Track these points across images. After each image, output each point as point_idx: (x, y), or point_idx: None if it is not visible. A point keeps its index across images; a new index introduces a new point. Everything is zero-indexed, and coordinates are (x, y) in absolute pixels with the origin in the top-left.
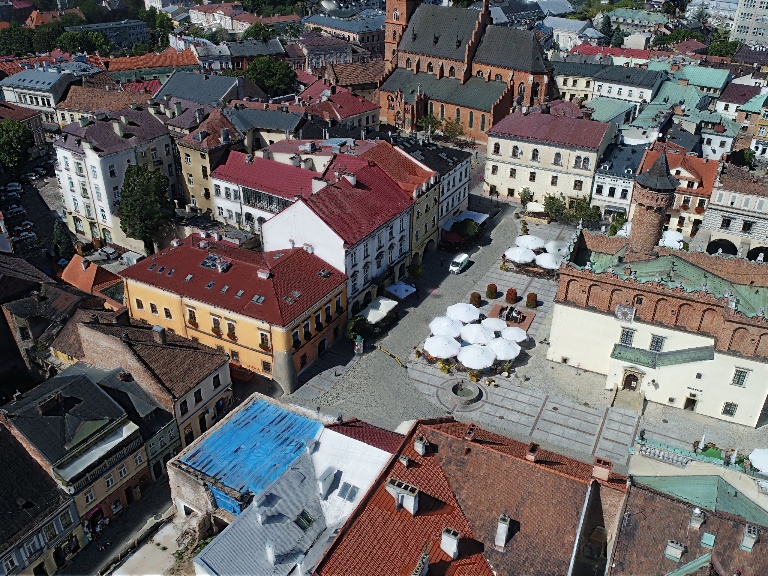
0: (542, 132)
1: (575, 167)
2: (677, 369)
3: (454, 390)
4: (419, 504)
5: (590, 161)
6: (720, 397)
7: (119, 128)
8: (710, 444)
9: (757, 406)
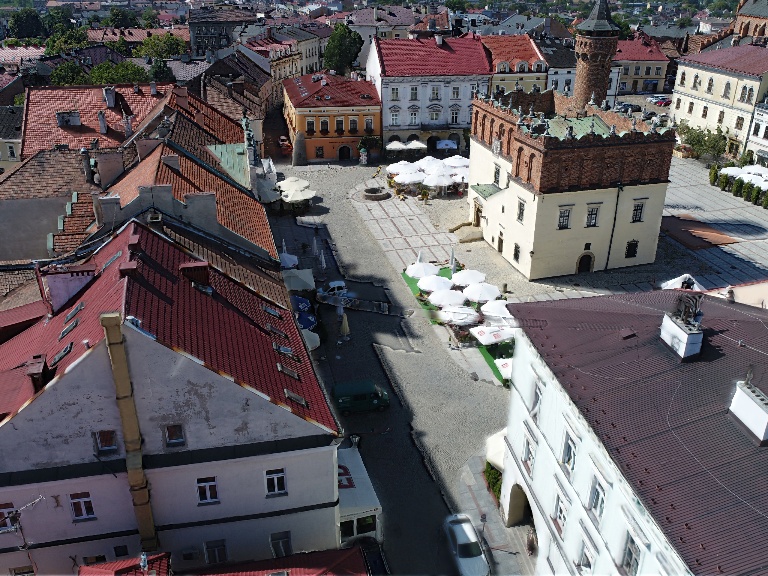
0: (725, 60)
1: (739, 100)
2: (495, 200)
3: (374, 193)
4: (118, 107)
5: (753, 92)
6: (513, 237)
7: (375, 12)
8: (462, 264)
9: (530, 250)
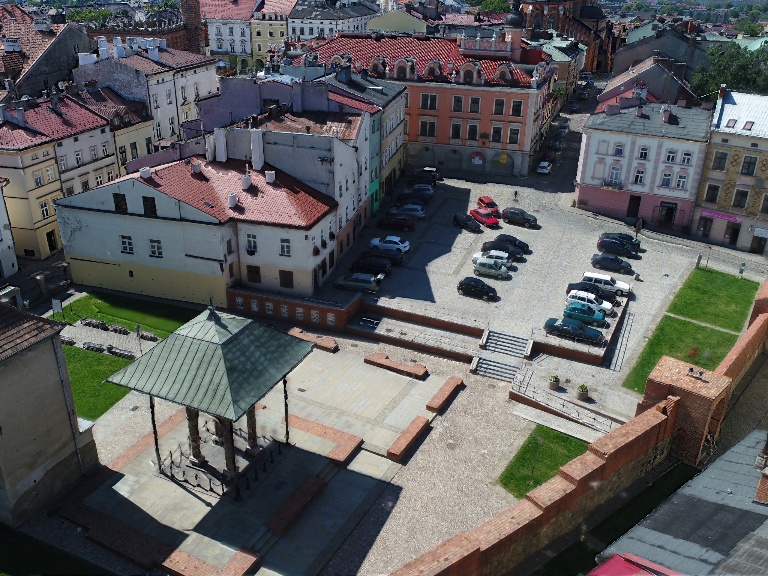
0: None
1: None
2: None
3: None
4: None
5: None
6: None
7: None
8: None
9: None
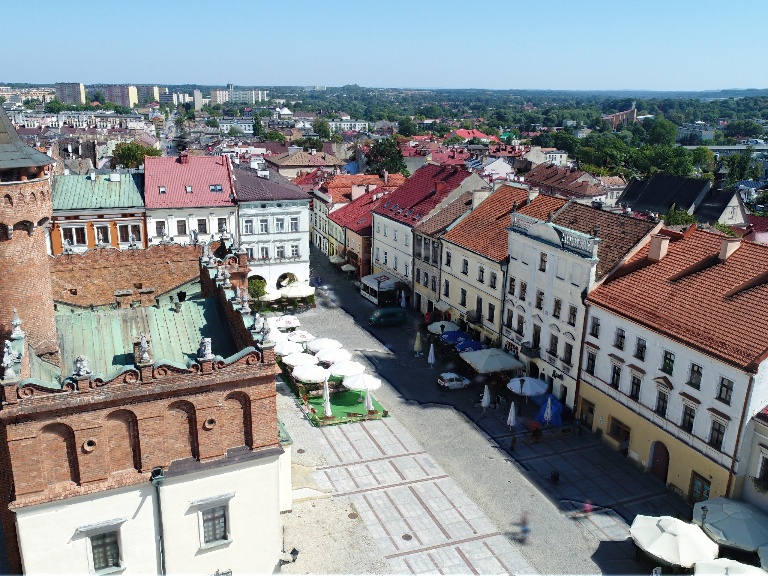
0: None
1: None
2: None
3: None
4: None
5: None
6: None
7: None
8: None
9: None
